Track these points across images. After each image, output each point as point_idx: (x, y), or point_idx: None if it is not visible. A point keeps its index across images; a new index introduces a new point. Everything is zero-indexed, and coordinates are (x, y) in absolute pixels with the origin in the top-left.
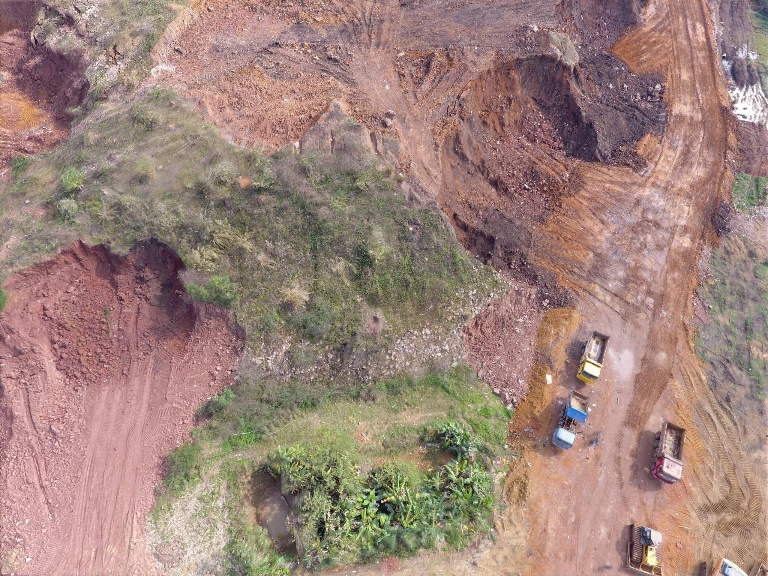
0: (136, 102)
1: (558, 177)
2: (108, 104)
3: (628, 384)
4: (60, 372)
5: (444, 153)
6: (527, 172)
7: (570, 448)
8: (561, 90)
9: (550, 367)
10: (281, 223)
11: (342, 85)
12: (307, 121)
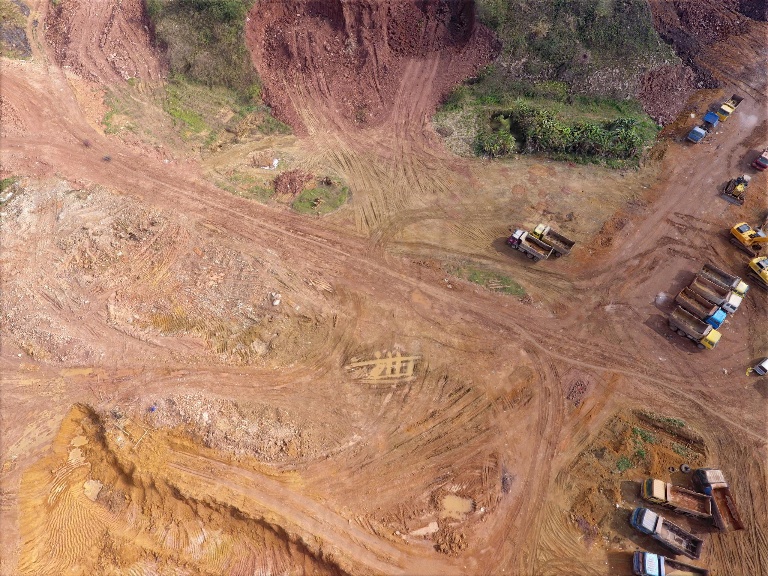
0: None
1: (730, 22)
2: None
3: (749, 129)
4: (389, 46)
5: None
6: (707, 15)
7: (698, 145)
8: None
9: (695, 111)
10: None
11: None
12: None
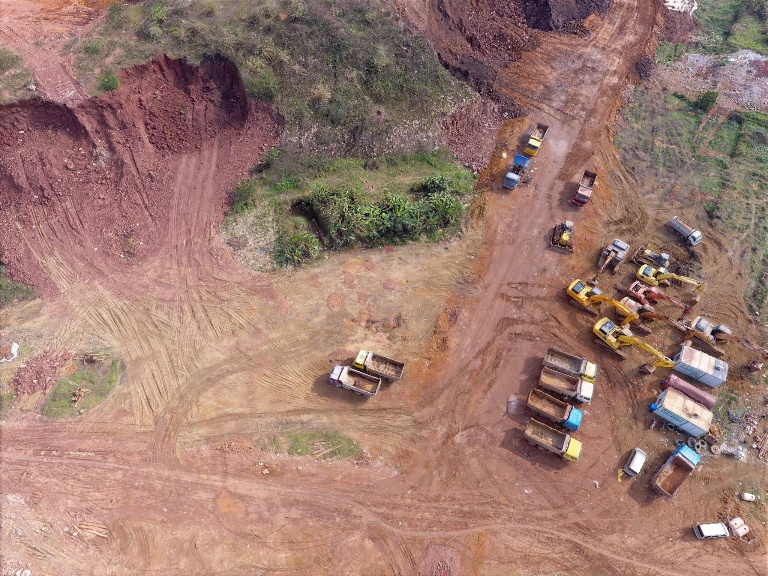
0: None
1: (520, 38)
2: None
3: (561, 158)
4: (152, 145)
5: (431, 8)
6: (496, 35)
7: (517, 190)
8: None
9: (506, 149)
10: (311, 43)
11: None
12: None
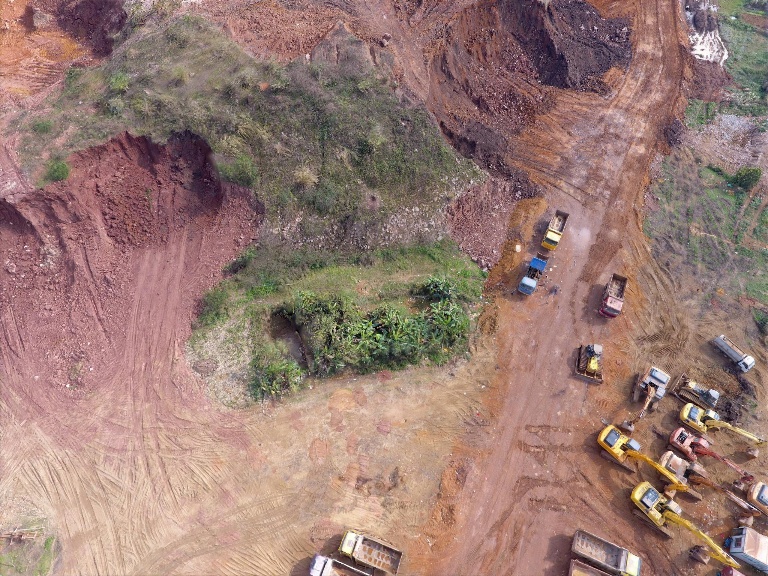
0: (169, 26)
1: (533, 98)
2: (145, 29)
3: (584, 252)
4: (110, 238)
5: (433, 70)
6: (506, 94)
7: (533, 296)
8: (537, 26)
9: (520, 240)
10: (294, 118)
11: (346, 14)
12: (316, 40)
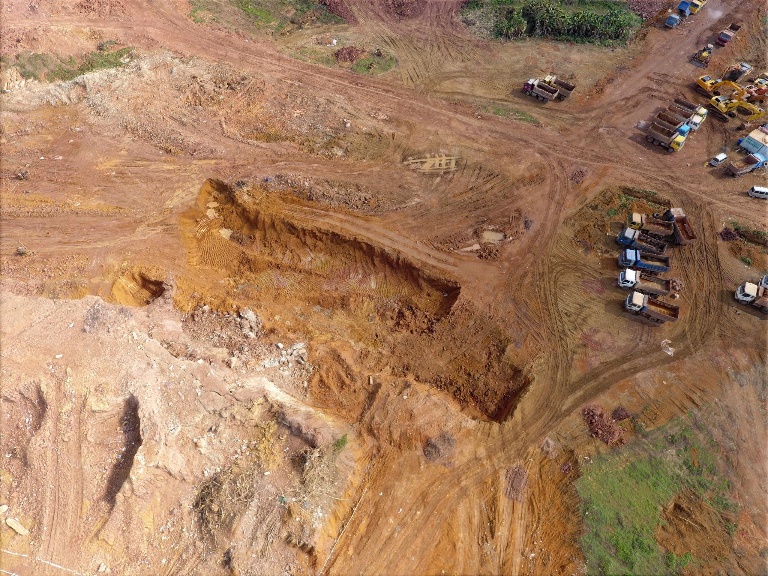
0: None
1: None
2: None
3: (715, 19)
4: None
5: None
6: None
7: (674, 30)
8: None
9: (672, 7)
10: None
11: None
12: None
